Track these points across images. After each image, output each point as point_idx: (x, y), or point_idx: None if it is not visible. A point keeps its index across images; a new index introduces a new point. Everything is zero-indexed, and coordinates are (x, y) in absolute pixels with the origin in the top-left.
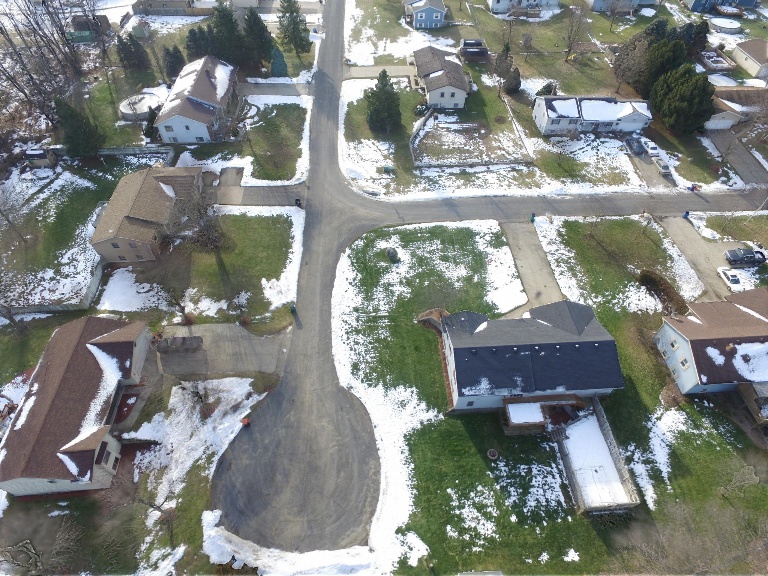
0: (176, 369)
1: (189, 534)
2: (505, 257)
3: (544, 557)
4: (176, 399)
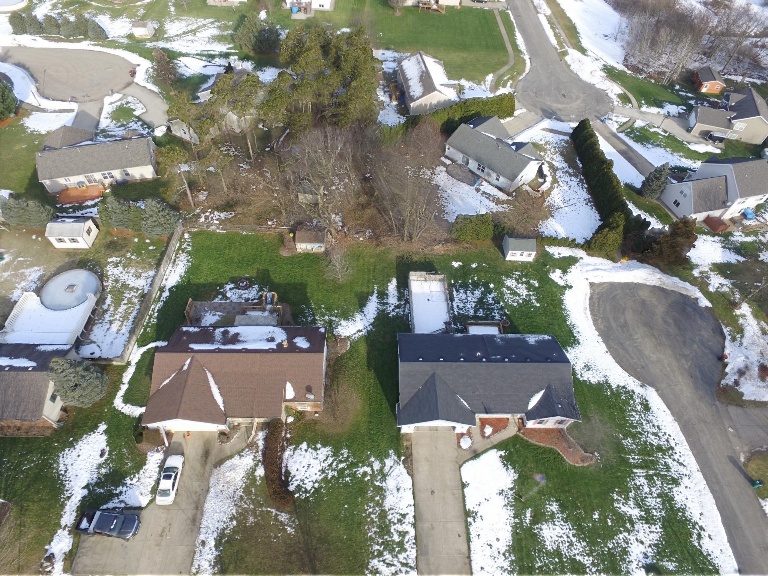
0: None
1: (713, 296)
2: (484, 560)
3: (474, 266)
4: None
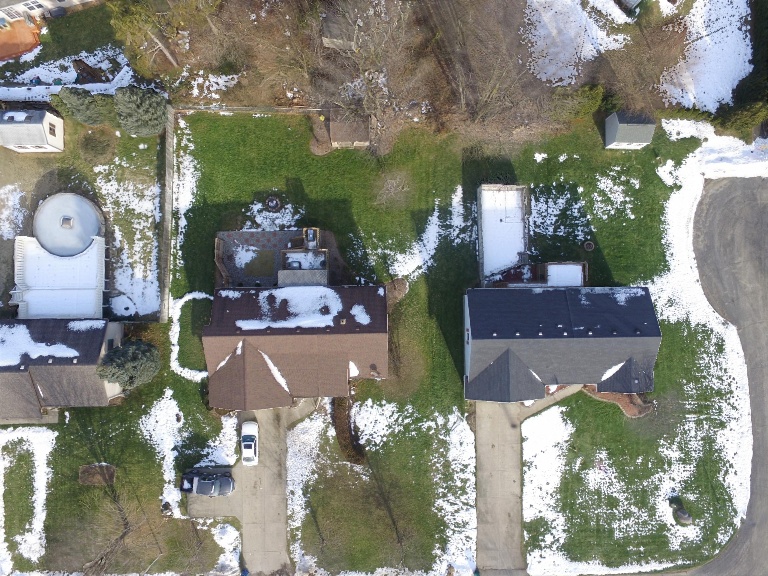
0: None
1: None
2: (534, 500)
3: (563, 158)
4: None
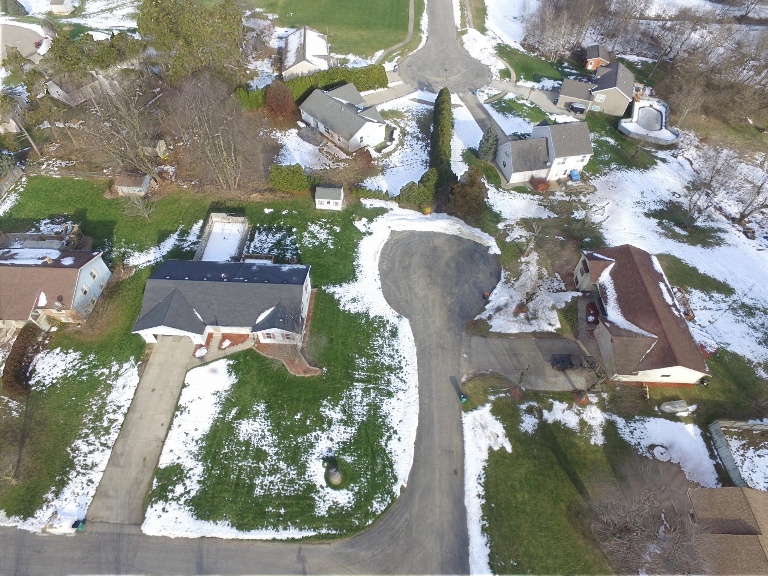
0: (566, 344)
1: (506, 245)
2: (175, 444)
3: (285, 212)
4: (553, 317)
